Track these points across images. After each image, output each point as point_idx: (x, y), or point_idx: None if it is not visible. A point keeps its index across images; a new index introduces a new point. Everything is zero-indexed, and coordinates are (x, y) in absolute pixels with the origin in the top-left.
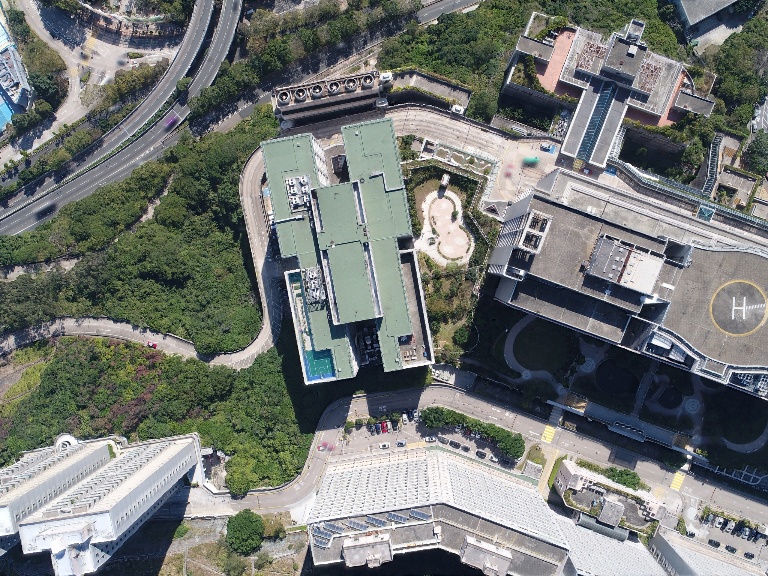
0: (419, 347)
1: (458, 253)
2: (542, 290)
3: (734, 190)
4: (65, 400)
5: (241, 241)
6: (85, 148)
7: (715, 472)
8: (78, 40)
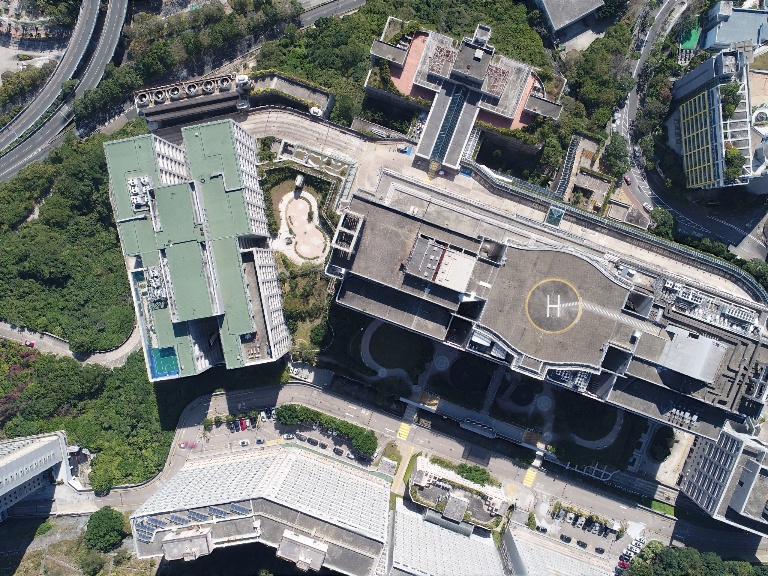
0: (263, 345)
1: (315, 253)
2: (368, 288)
3: (591, 192)
4: None
5: None
6: None
7: (567, 468)
8: None
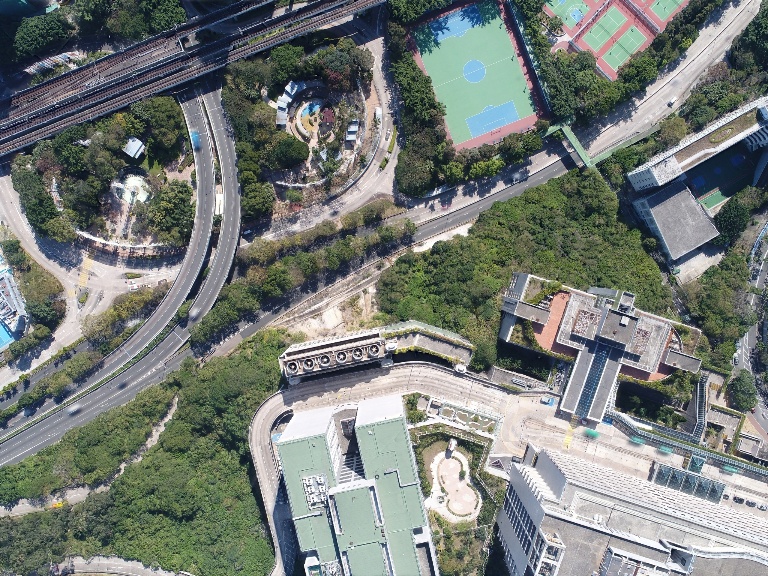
0: None
1: (467, 509)
2: None
3: (721, 426)
4: None
5: None
6: (86, 371)
7: None
8: (74, 262)
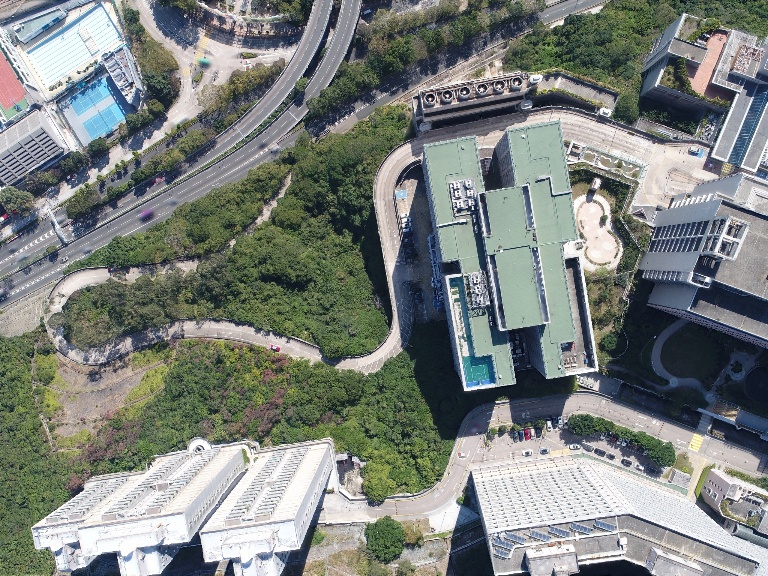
0: (580, 354)
1: (606, 258)
2: (722, 297)
3: None
4: (195, 404)
5: (361, 244)
6: (198, 149)
7: None
8: (191, 40)
